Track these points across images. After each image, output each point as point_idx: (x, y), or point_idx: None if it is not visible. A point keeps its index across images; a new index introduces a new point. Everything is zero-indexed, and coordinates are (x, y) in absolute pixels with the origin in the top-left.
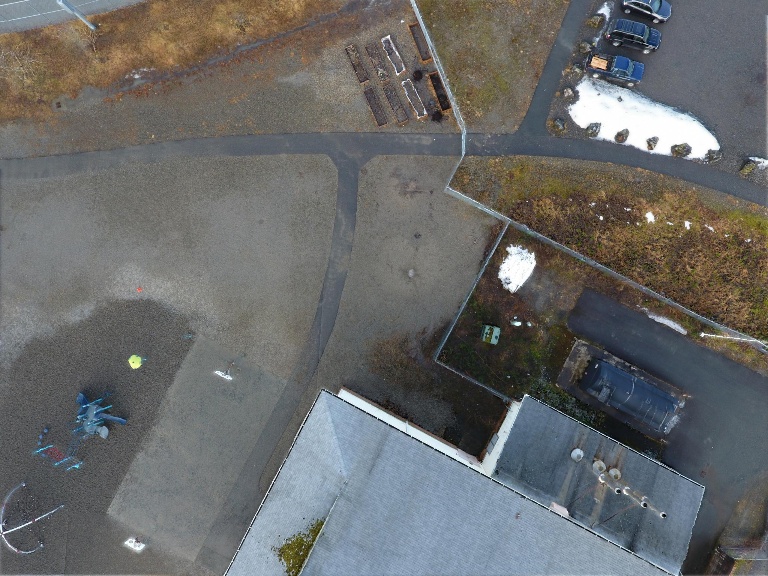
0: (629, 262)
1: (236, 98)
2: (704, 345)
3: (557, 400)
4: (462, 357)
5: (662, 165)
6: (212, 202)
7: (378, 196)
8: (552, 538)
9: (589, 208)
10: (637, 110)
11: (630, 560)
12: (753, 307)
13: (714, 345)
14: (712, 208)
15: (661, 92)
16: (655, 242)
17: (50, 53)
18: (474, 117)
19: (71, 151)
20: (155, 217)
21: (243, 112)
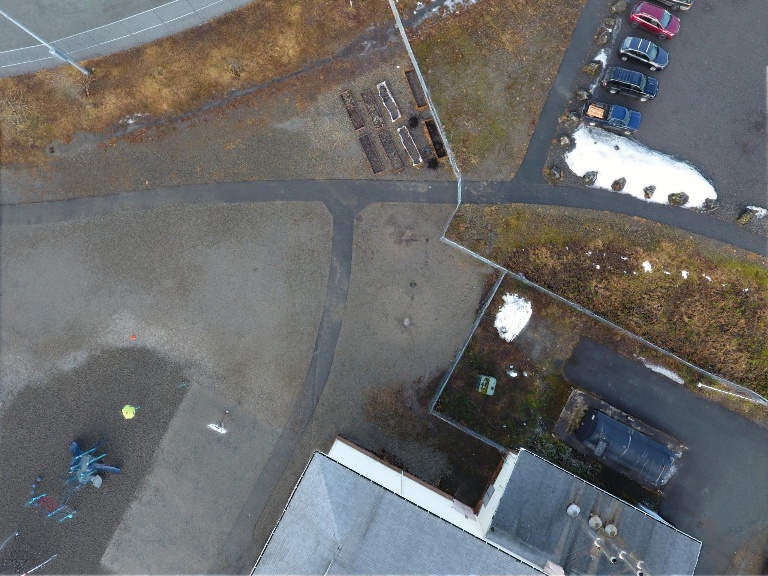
0: (626, 312)
1: (231, 144)
2: (701, 395)
3: (553, 450)
4: (458, 407)
5: (659, 214)
6: (206, 249)
7: (373, 244)
8: None
9: (586, 257)
10: (634, 159)
11: None
12: (751, 357)
13: (711, 395)
14: (709, 257)
15: (658, 140)
16: (652, 292)
17: (43, 98)
18: (470, 164)
19: (64, 197)
20: (149, 264)
21: (238, 158)
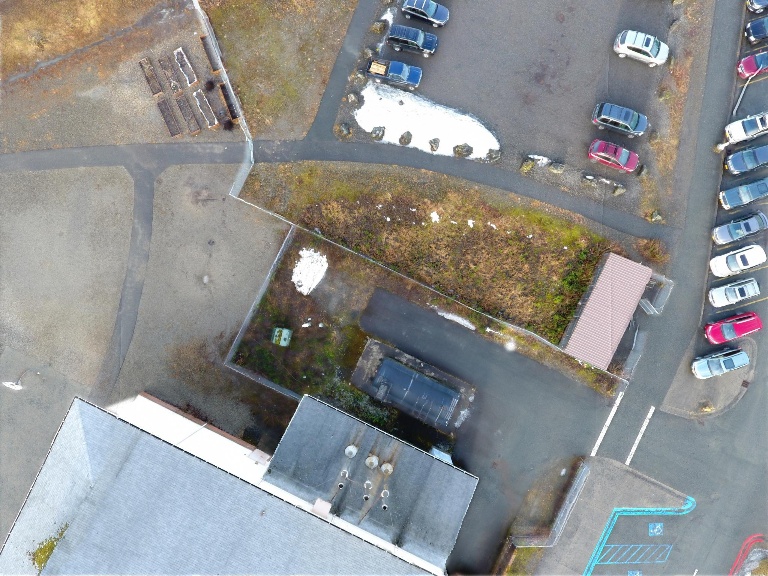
0: (415, 261)
1: (36, 114)
2: (492, 340)
3: (351, 398)
4: (258, 359)
5: (445, 166)
6: (13, 216)
7: (173, 205)
8: (295, 533)
9: (376, 210)
10: (417, 113)
11: (372, 552)
12: (536, 301)
13: (501, 339)
14: (494, 206)
15: (443, 94)
16: (439, 241)
17: None
18: (264, 125)
19: None
20: None
21: (43, 127)
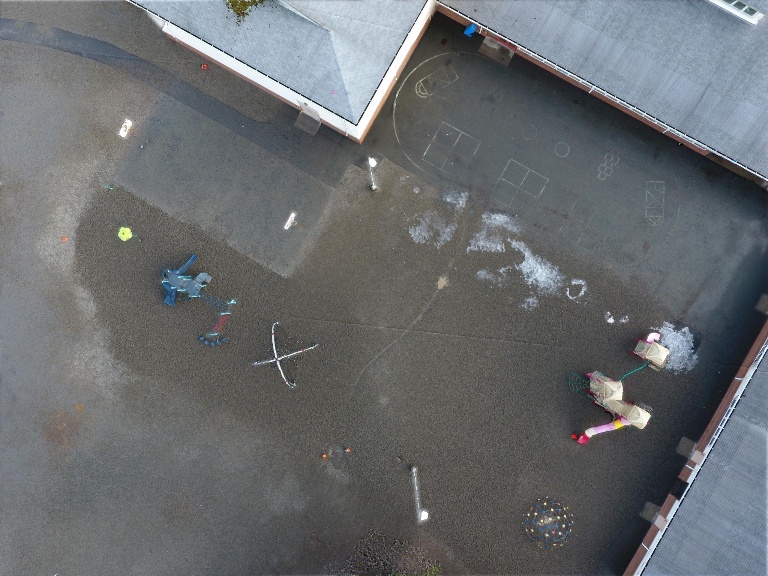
0: None
1: None
2: None
3: None
4: None
5: None
6: None
7: None
8: None
9: None
10: None
11: None
12: None
13: None
14: None
15: None
16: None
17: None
18: None
19: None
20: None
21: None
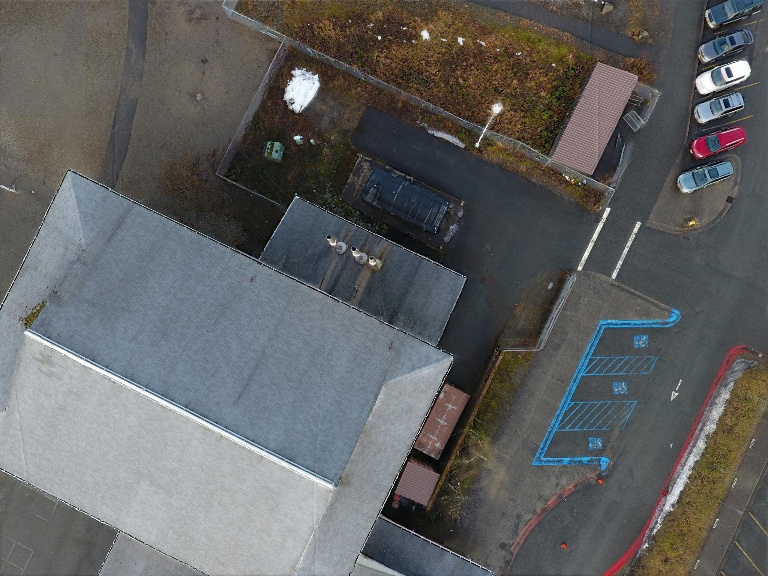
0: (406, 78)
1: None
2: (481, 157)
3: (342, 214)
4: (250, 176)
5: None
6: (9, 37)
7: (167, 25)
8: (284, 298)
9: (367, 29)
10: None
11: (360, 318)
12: (524, 117)
13: (490, 156)
14: (484, 24)
15: None
16: (430, 58)
17: None
18: None
19: None
20: None
21: None
